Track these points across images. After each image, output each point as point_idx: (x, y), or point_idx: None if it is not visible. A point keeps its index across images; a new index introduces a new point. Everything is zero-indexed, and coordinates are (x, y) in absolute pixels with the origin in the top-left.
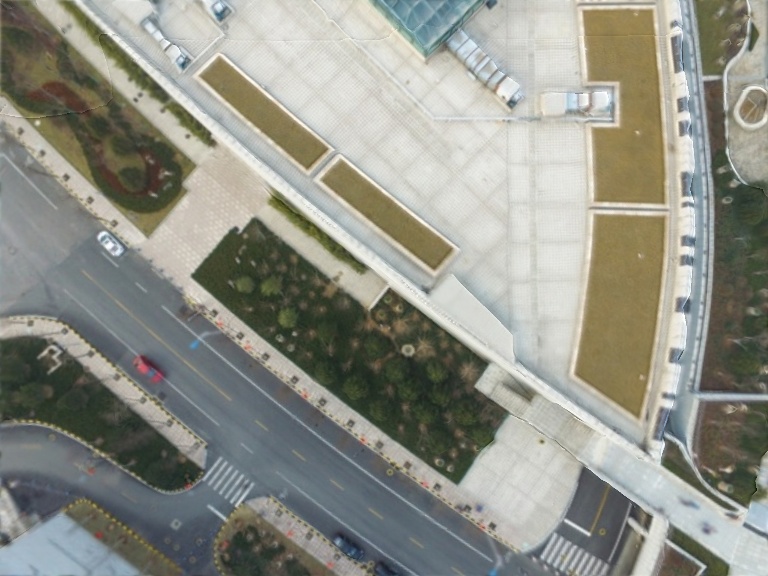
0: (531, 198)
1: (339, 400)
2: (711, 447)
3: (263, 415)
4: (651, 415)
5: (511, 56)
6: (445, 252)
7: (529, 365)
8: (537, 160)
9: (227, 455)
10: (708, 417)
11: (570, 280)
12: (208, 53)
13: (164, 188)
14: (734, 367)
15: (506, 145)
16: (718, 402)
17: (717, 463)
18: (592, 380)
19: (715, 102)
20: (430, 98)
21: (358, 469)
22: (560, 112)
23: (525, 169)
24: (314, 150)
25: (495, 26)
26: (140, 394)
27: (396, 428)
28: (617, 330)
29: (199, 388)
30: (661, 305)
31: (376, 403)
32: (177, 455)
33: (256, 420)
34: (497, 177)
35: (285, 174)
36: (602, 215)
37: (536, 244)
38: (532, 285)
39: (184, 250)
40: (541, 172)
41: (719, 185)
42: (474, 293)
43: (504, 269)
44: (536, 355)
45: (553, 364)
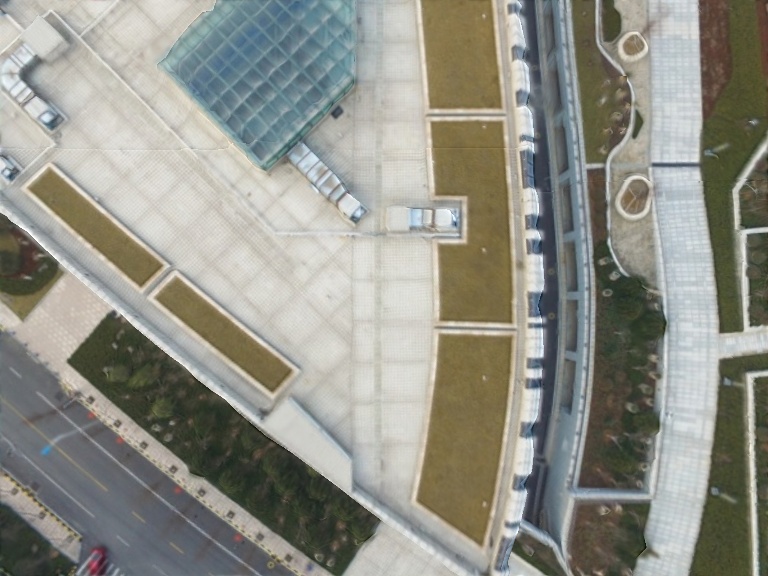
0: (376, 315)
1: (218, 491)
2: (585, 549)
3: (140, 506)
4: (495, 542)
5: (357, 167)
6: (284, 374)
7: (371, 490)
8: (383, 276)
9: (102, 548)
10: (582, 518)
11: (415, 401)
12: (38, 163)
13: (39, 270)
14: (610, 465)
15: (351, 260)
16: (593, 502)
17: (591, 565)
18: (434, 507)
19: (597, 191)
20: (273, 211)
21: (238, 562)
22: (404, 228)
23: (370, 285)
24: (148, 267)
25: (340, 137)
26: (12, 485)
27: (276, 521)
28: (461, 454)
29: (74, 478)
30: (507, 428)
31: (251, 498)
32: (49, 549)
33: (133, 511)
34: (341, 294)
35: (118, 291)
36: (447, 335)
37: (381, 363)
38: (376, 406)
39: (60, 334)
40: (387, 288)
41: (600, 277)
42: (315, 415)
43: (347, 390)
44: (379, 479)
45: (396, 489)
